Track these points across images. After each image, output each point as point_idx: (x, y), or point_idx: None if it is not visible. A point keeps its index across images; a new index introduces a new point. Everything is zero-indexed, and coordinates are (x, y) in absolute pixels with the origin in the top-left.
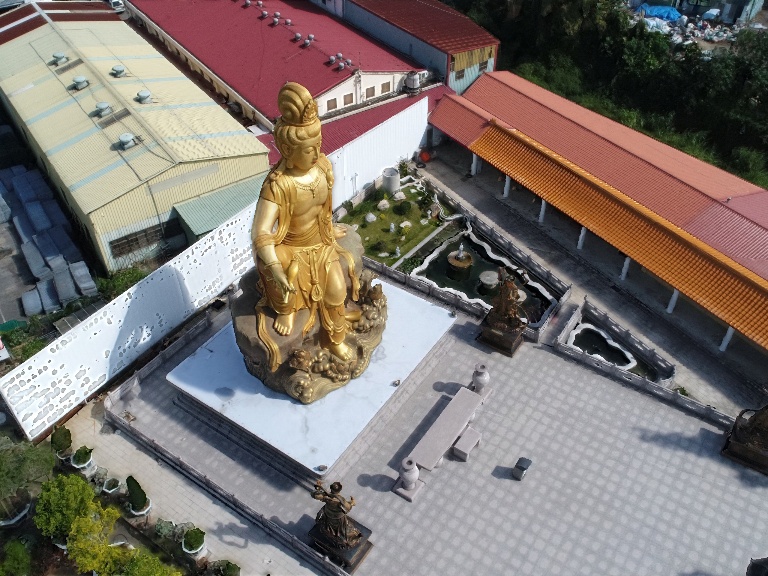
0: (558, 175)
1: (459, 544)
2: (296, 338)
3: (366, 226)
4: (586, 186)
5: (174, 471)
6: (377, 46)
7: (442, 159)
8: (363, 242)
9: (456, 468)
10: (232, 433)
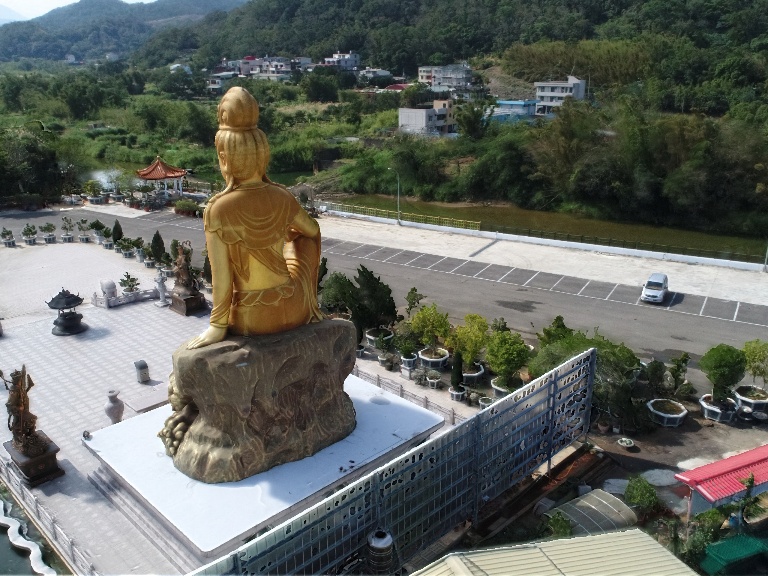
0: None
1: None
2: None
3: None
4: None
5: None
6: None
7: None
8: None
9: None
10: None
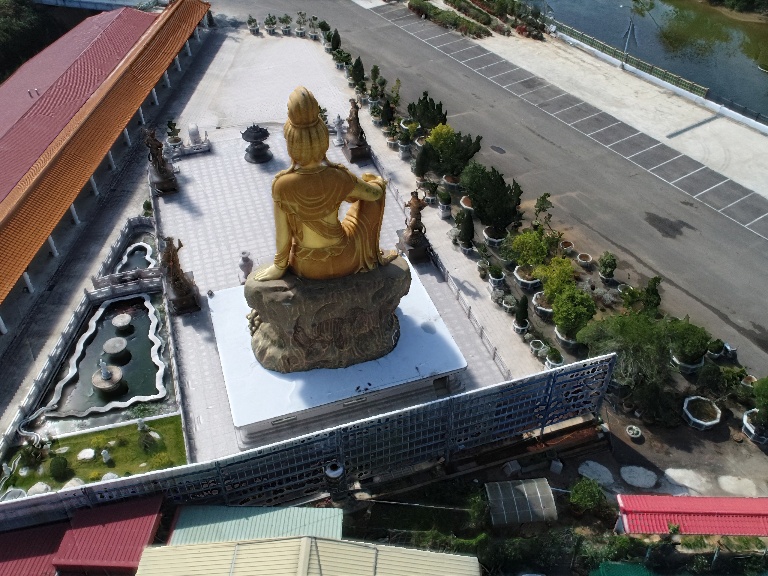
0: None
1: None
2: None
3: None
4: None
5: None
6: None
7: None
8: None
9: None
10: None
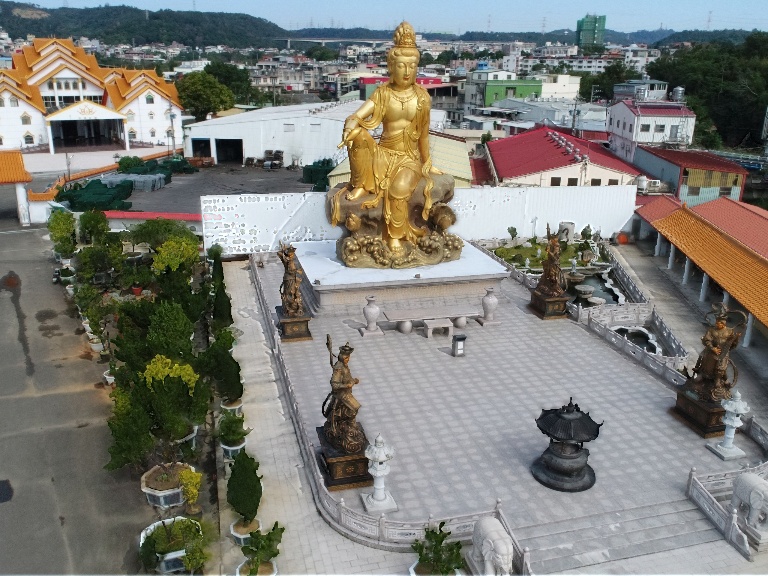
0: (706, 235)
1: (366, 359)
2: (355, 205)
3: (519, 248)
4: (722, 239)
5: (254, 287)
6: (639, 172)
7: (639, 245)
8: (508, 256)
9: (416, 338)
10: (301, 282)
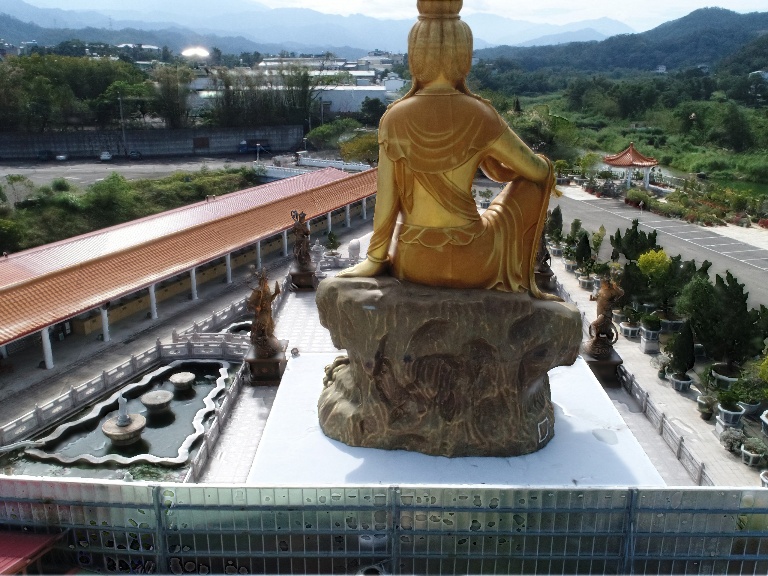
0: None
1: None
2: None
3: None
4: None
5: None
6: None
7: None
8: None
9: None
10: None
